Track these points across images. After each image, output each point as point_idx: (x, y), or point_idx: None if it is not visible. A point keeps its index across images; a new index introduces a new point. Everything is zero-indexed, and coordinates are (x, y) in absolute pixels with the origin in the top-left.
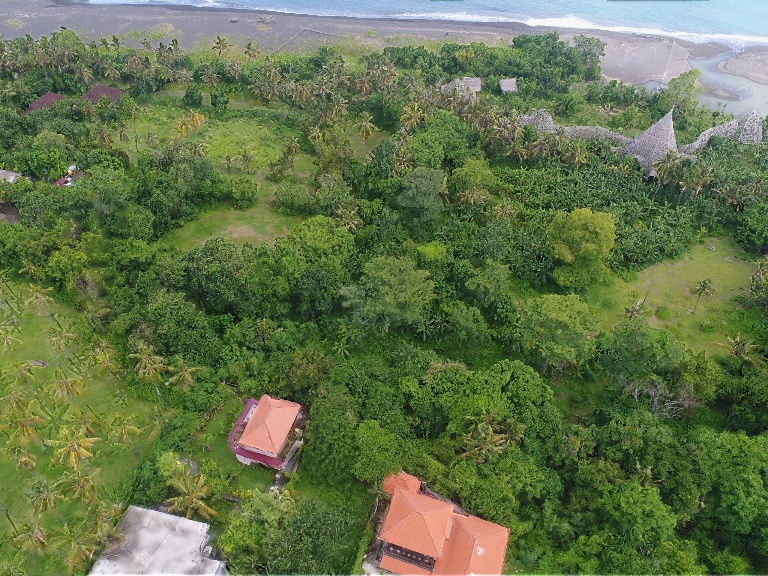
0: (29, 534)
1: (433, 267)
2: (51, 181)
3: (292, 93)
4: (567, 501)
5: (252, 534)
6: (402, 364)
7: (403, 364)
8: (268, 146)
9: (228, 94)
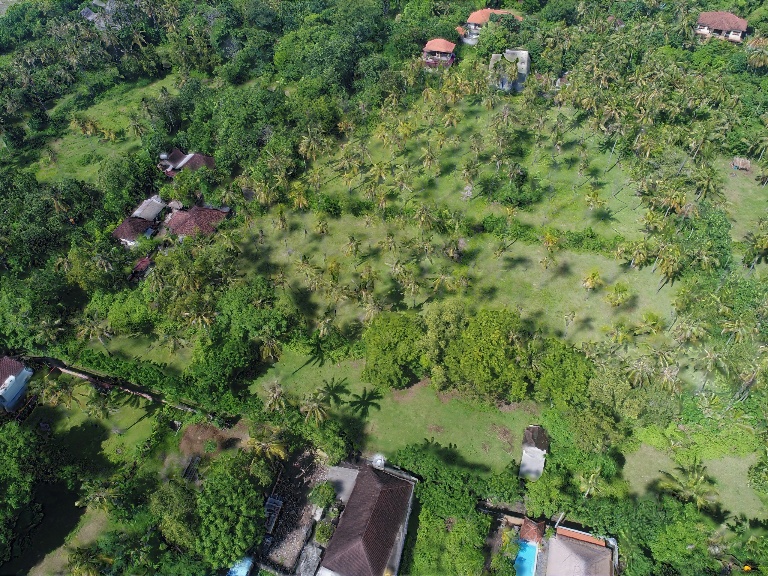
0: (516, 68)
1: (324, 22)
2: (163, 184)
3: (91, 57)
4: (460, 5)
5: (500, 32)
6: (390, 36)
7: (390, 36)
8: (130, 101)
9: (1, 133)
